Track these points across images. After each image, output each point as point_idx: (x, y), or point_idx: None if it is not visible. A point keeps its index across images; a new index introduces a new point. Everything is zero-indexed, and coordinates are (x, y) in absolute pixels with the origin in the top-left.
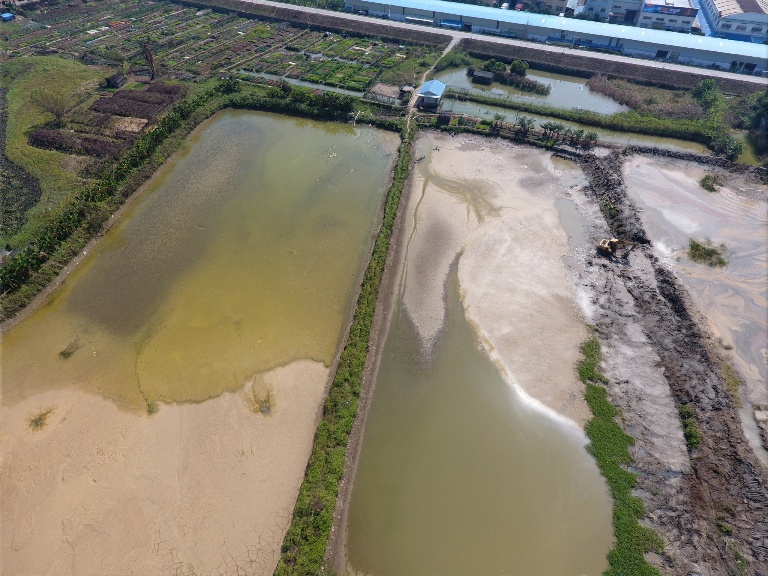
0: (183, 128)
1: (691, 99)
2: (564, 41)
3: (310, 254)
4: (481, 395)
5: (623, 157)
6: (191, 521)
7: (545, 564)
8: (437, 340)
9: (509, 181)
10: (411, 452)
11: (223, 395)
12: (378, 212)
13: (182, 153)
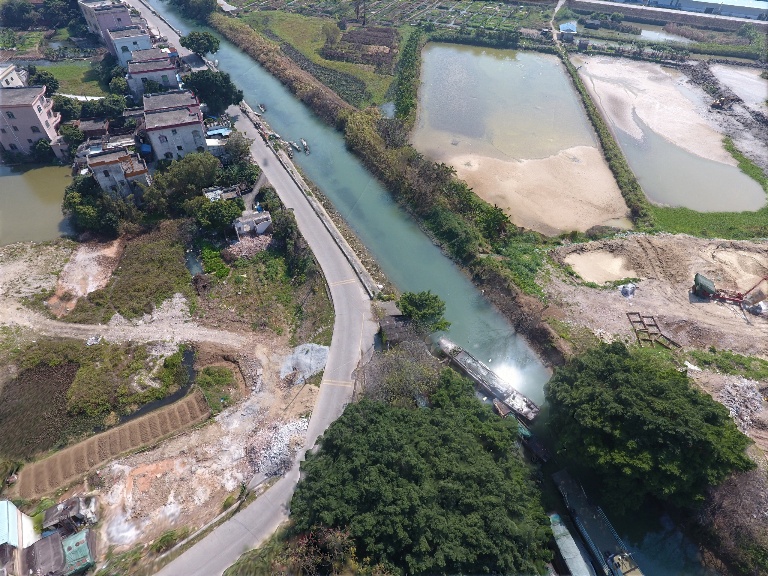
0: (418, 50)
1: (737, 37)
2: (637, 2)
3: (549, 108)
4: (680, 157)
5: (708, 65)
6: (574, 191)
7: (739, 202)
8: (645, 139)
9: (641, 78)
10: (659, 173)
11: (551, 157)
12: (573, 91)
13: (425, 64)
